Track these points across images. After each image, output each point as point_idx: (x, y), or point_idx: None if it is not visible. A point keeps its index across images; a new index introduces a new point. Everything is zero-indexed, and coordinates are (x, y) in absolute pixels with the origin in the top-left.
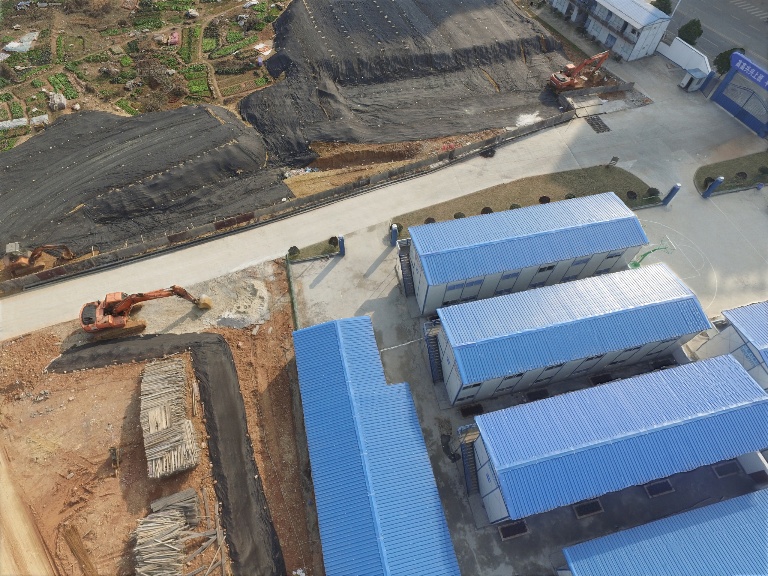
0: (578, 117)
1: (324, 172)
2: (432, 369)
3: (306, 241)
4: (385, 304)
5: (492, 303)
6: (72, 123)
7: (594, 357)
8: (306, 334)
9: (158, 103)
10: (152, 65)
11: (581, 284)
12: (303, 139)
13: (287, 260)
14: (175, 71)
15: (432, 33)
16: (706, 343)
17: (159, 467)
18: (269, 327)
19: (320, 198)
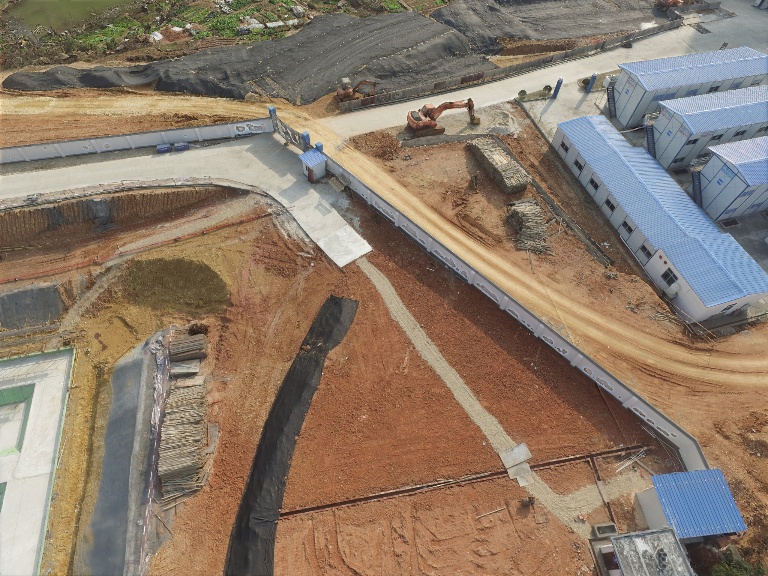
0: (684, 25)
1: (514, 56)
2: (649, 149)
3: None
4: None
5: (693, 98)
6: (329, 20)
7: (763, 128)
8: (568, 124)
9: None
10: None
11: (745, 90)
12: (492, 35)
13: (517, 101)
14: None
15: None
16: None
17: (513, 181)
18: (524, 134)
19: (521, 68)
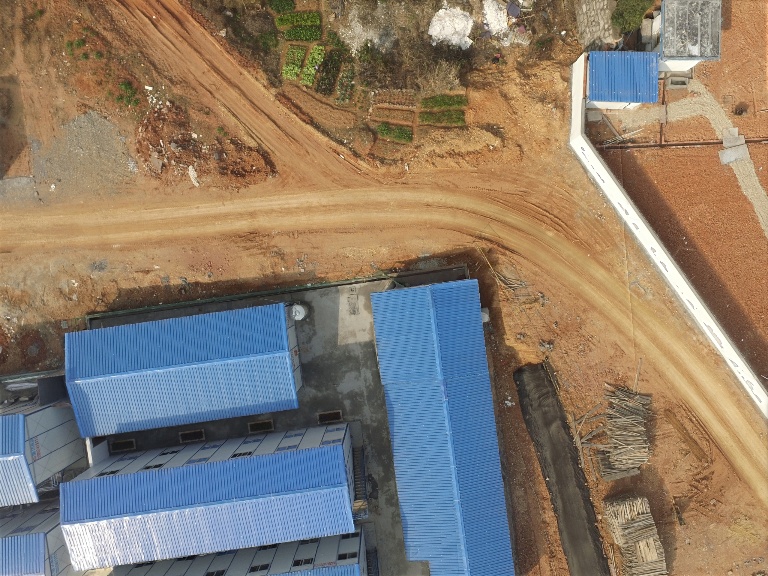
0: None
1: None
2: (377, 567)
3: None
4: None
5: None
6: None
7: (215, 575)
8: None
9: None
10: None
11: None
12: None
13: None
14: None
15: None
16: (85, 572)
17: (640, 507)
18: None
19: None
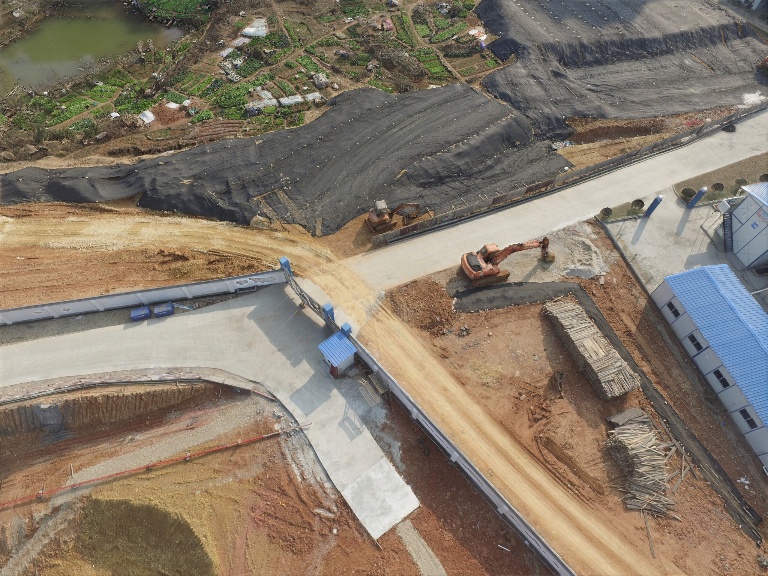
0: None
1: (588, 144)
2: None
3: (606, 204)
4: (707, 258)
5: None
6: (358, 99)
7: None
8: (679, 279)
9: (409, 82)
10: (384, 49)
11: None
12: (560, 115)
13: (599, 221)
14: (407, 54)
15: (636, 19)
16: None
17: (614, 387)
18: (613, 278)
19: (600, 167)
